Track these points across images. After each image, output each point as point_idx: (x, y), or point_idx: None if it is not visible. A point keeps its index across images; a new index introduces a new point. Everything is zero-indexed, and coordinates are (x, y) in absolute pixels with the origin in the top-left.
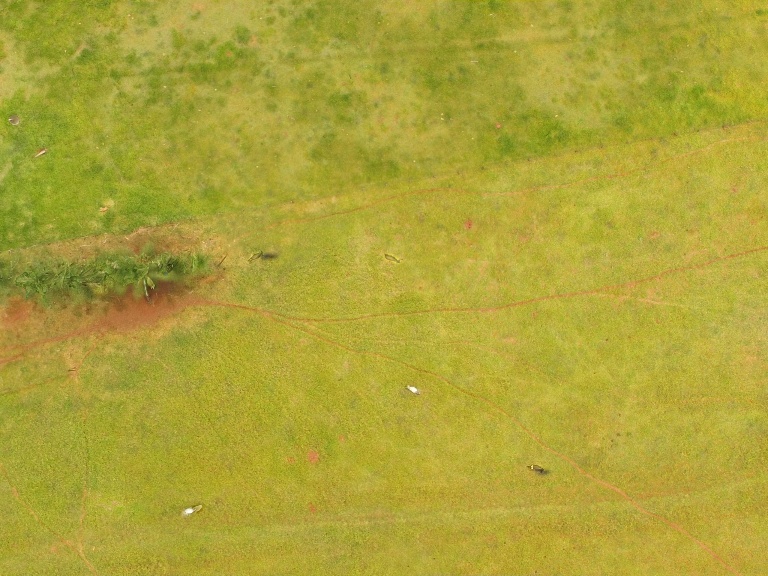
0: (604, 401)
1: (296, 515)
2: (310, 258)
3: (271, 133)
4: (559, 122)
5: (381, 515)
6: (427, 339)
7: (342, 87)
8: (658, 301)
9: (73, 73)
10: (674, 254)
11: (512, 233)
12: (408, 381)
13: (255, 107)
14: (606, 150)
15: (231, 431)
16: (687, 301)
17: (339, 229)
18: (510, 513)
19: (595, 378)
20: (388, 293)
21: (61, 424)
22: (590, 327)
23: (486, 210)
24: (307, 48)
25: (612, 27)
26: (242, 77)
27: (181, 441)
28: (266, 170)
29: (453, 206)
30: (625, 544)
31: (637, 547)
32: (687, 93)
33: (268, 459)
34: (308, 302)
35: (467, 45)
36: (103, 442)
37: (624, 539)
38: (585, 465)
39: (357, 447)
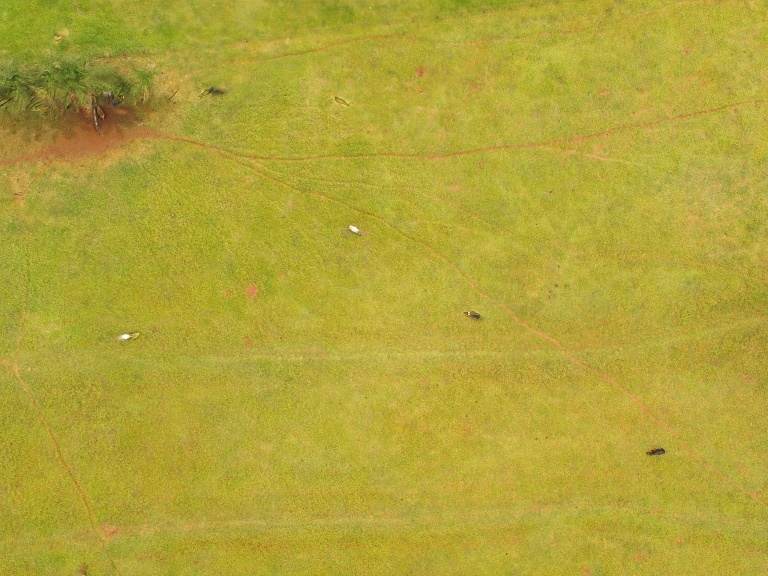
0: (544, 252)
1: (232, 347)
2: (260, 97)
3: None
4: None
5: (316, 352)
6: (372, 182)
7: None
8: (604, 157)
9: None
10: (623, 111)
11: (463, 83)
12: (351, 222)
13: None
14: (561, 6)
15: (172, 262)
16: (633, 158)
17: (291, 70)
18: (444, 356)
19: (537, 229)
20: (336, 135)
21: (4, 246)
22: (535, 179)
23: (438, 59)
24: None
25: None
26: None
27: (122, 269)
28: (222, 9)
29: (406, 53)
30: (557, 393)
31: (568, 397)
32: None
33: (207, 291)
34: (256, 140)
35: None
36: (44, 265)
37: (556, 388)
38: (522, 314)
39: (296, 284)
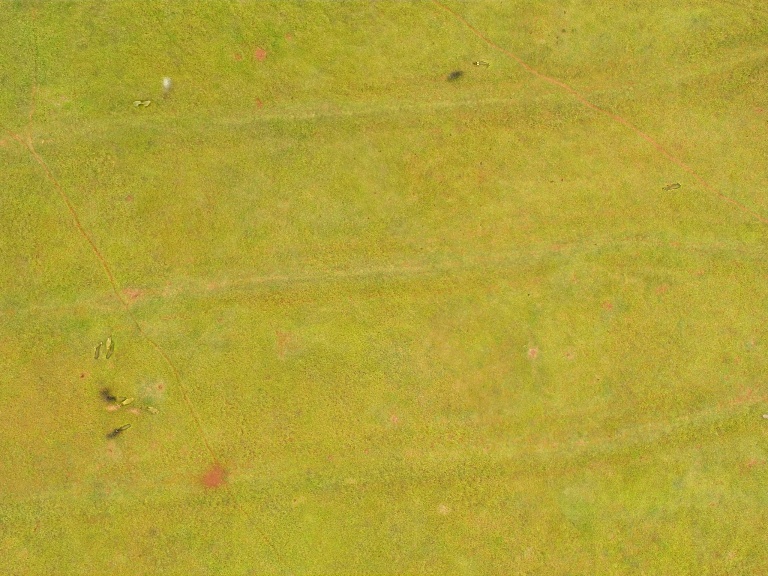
0: None
1: (243, 109)
2: None
3: None
4: None
5: (328, 109)
6: None
7: None
8: None
9: None
10: None
11: None
12: None
13: None
14: None
15: (179, 29)
16: None
17: None
18: (456, 106)
19: None
20: None
21: (10, 23)
22: None
23: None
24: None
25: None
26: None
27: (129, 39)
28: None
29: None
30: (570, 136)
31: (581, 139)
32: None
33: (216, 55)
34: None
35: None
36: (52, 38)
37: (569, 131)
38: (530, 60)
39: (304, 44)
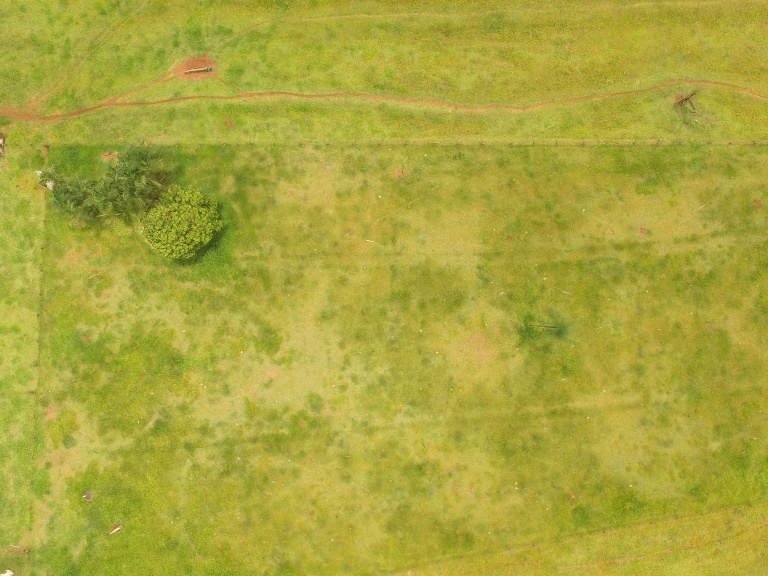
0: None
1: None
2: None
3: (345, 505)
4: (634, 493)
5: None
6: None
7: (416, 456)
8: None
9: (146, 446)
10: None
11: None
12: None
13: (329, 478)
14: (681, 521)
15: None
16: None
17: None
18: None
19: None
20: None
21: None
22: None
23: None
24: (380, 416)
25: (684, 392)
26: (316, 447)
27: None
28: (341, 543)
29: None
30: None
31: None
32: (761, 462)
33: None
34: None
35: (540, 412)
36: None
37: None
38: None
39: None
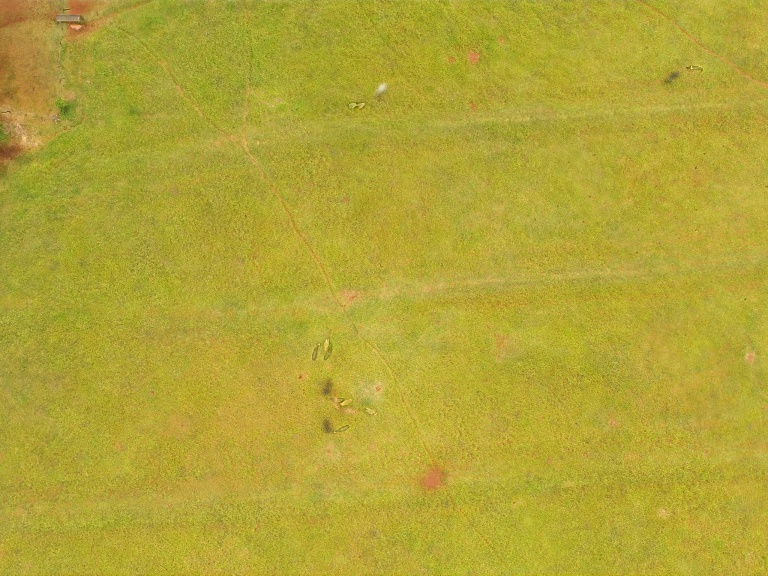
0: (763, 3)
1: (458, 112)
2: None
3: None
4: None
5: (542, 112)
6: None
7: None
8: None
9: None
10: None
11: None
12: None
13: None
14: None
15: (393, 31)
16: None
17: None
18: (670, 110)
19: None
20: None
21: (224, 24)
22: None
23: None
24: None
25: None
26: None
27: (343, 41)
28: None
29: None
30: None
31: None
32: None
33: (430, 58)
34: None
35: None
36: (267, 40)
37: None
38: (744, 65)
39: (518, 47)
